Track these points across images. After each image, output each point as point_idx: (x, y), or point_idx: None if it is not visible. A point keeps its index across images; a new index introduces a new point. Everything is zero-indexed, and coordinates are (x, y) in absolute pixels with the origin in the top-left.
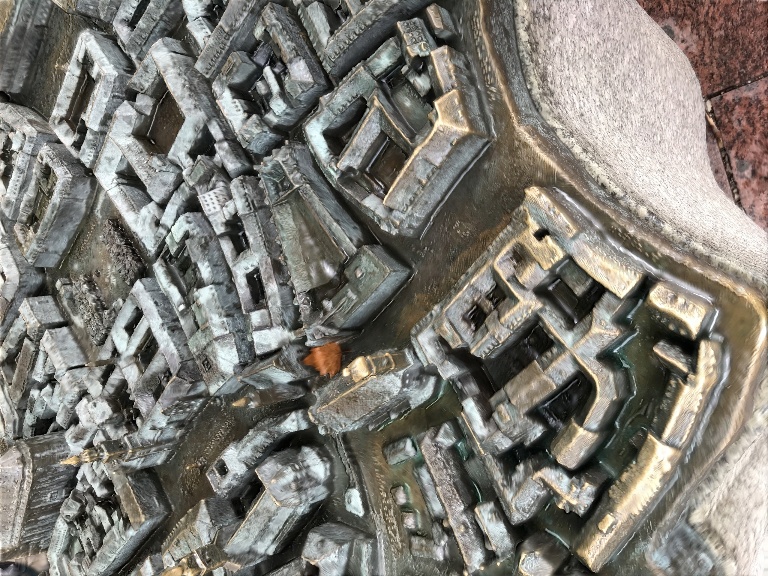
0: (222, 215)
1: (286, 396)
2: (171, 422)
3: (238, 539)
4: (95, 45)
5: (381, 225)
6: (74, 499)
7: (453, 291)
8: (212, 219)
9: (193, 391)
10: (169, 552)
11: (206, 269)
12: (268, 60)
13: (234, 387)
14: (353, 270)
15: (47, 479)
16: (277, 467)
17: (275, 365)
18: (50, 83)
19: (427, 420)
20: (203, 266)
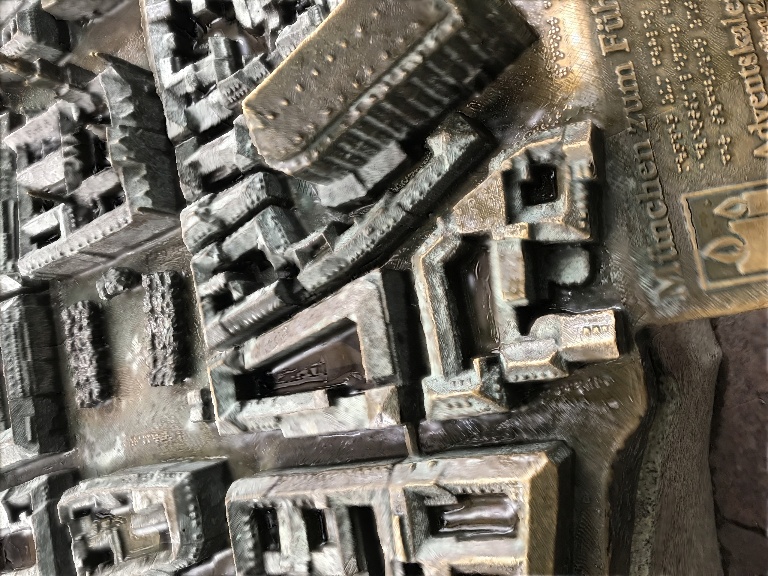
0: None
1: None
2: None
3: None
4: None
5: None
6: None
7: None
8: None
9: None
10: None
11: None
12: None
13: None
14: None
15: None
16: None
17: None
18: None
19: None
20: None
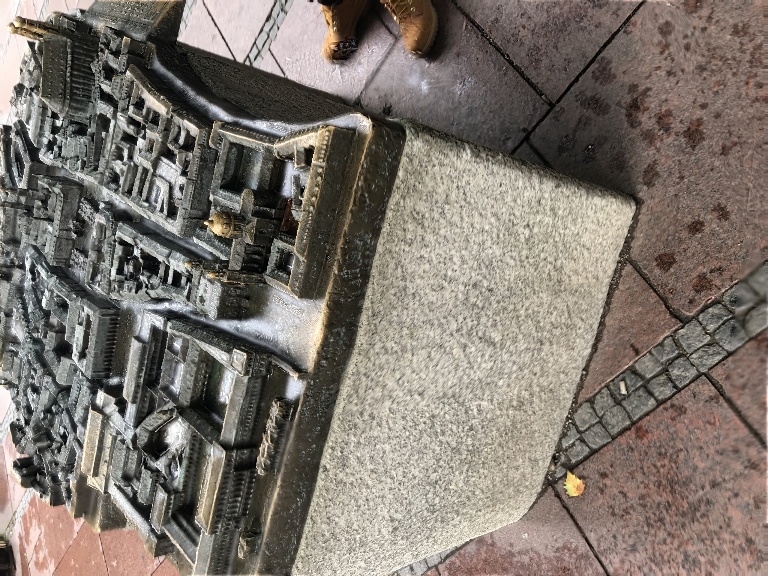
0: None
1: None
2: None
3: None
4: None
5: (10, 344)
6: None
7: (2, 335)
8: None
9: None
10: None
11: None
12: None
13: None
14: (13, 326)
15: None
16: (9, 248)
17: None
18: None
19: None
20: None
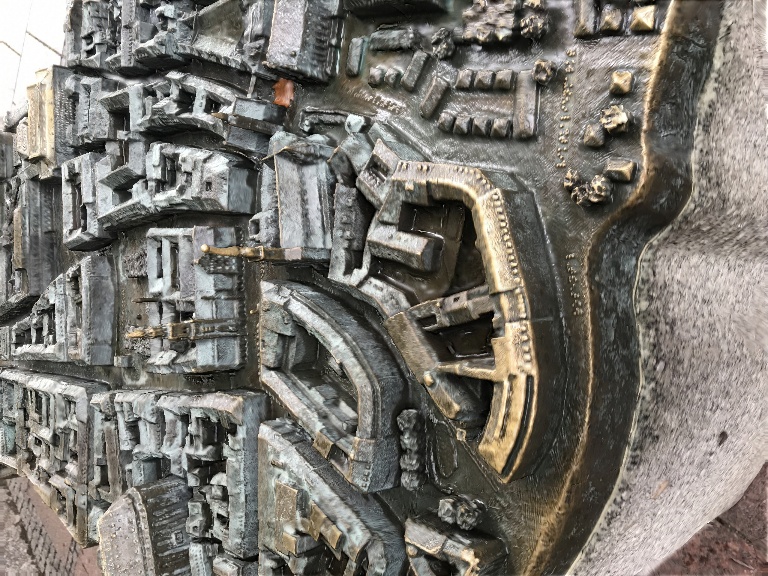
0: (173, 104)
1: (263, 121)
2: (219, 291)
3: (287, 234)
4: (72, 159)
5: None
6: (192, 502)
7: None
8: (168, 112)
9: (220, 243)
10: (263, 366)
11: (182, 149)
12: (160, 20)
13: (244, 201)
14: None
15: (163, 513)
16: None
17: (237, 95)
18: (67, 260)
19: (354, 16)
20: (179, 150)
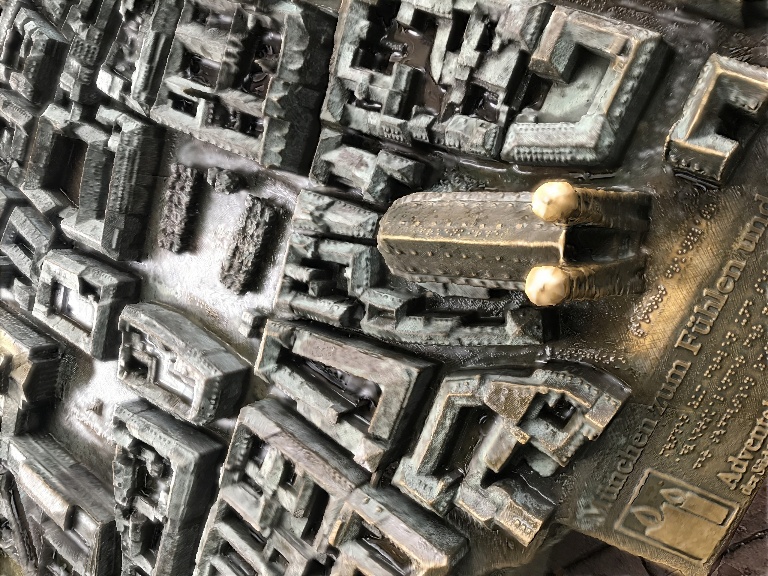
0: (84, 33)
1: None
2: None
3: None
4: None
5: None
6: None
7: None
8: None
9: None
10: None
11: None
12: None
13: None
14: None
15: None
16: None
17: None
18: None
19: None
20: None
